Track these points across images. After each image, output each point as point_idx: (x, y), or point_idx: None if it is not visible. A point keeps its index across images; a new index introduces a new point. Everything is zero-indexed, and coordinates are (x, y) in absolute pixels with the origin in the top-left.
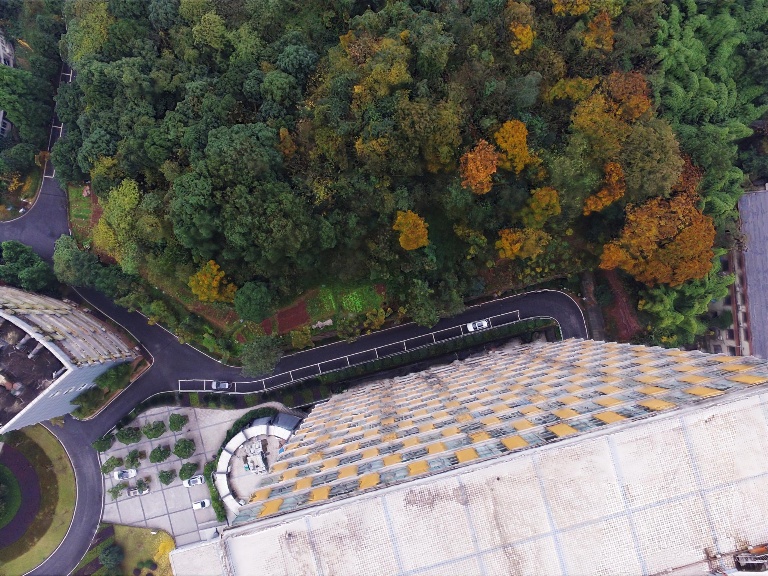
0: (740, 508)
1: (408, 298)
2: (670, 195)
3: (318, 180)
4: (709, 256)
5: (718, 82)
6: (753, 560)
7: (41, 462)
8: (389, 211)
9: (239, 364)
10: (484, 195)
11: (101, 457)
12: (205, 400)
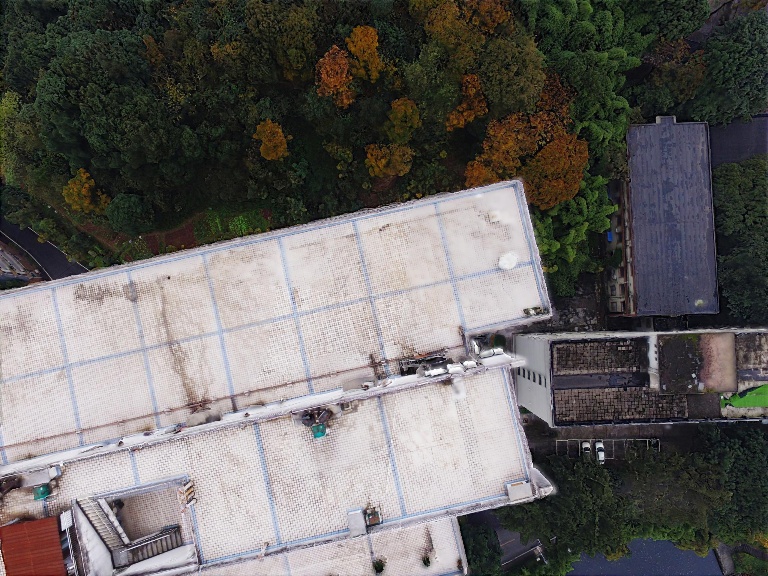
0: (409, 316)
1: (287, 219)
2: (534, 112)
3: (170, 81)
4: (576, 177)
5: (604, 10)
6: (412, 363)
7: None
8: (251, 121)
9: None
10: (350, 110)
11: None
12: None
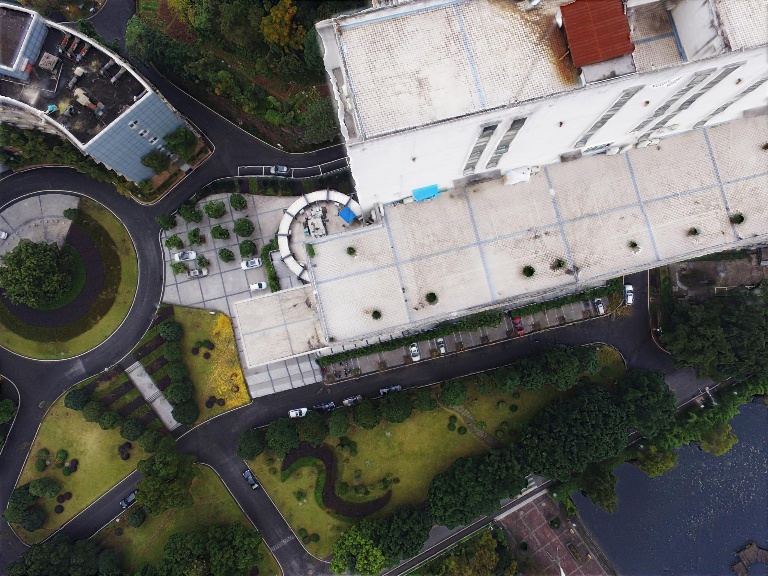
0: None
1: None
2: None
3: None
4: None
5: None
6: None
7: (105, 243)
8: None
9: (297, 150)
10: None
11: (162, 241)
12: (264, 184)
